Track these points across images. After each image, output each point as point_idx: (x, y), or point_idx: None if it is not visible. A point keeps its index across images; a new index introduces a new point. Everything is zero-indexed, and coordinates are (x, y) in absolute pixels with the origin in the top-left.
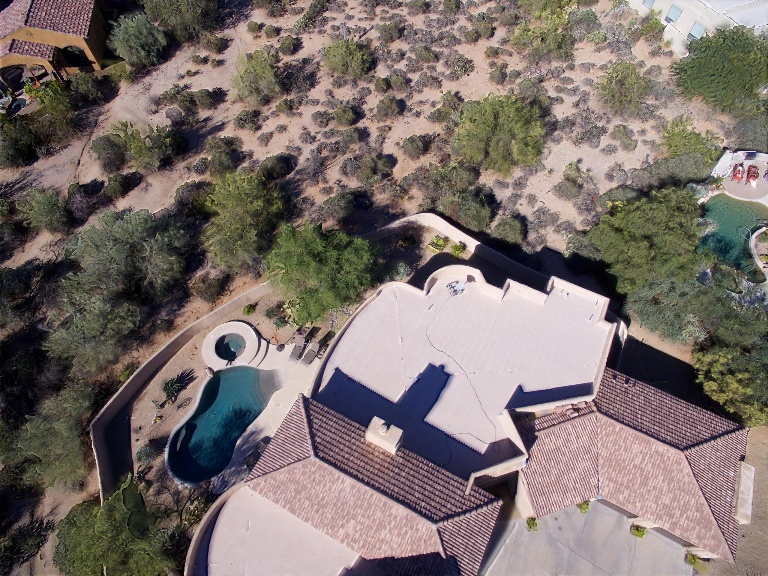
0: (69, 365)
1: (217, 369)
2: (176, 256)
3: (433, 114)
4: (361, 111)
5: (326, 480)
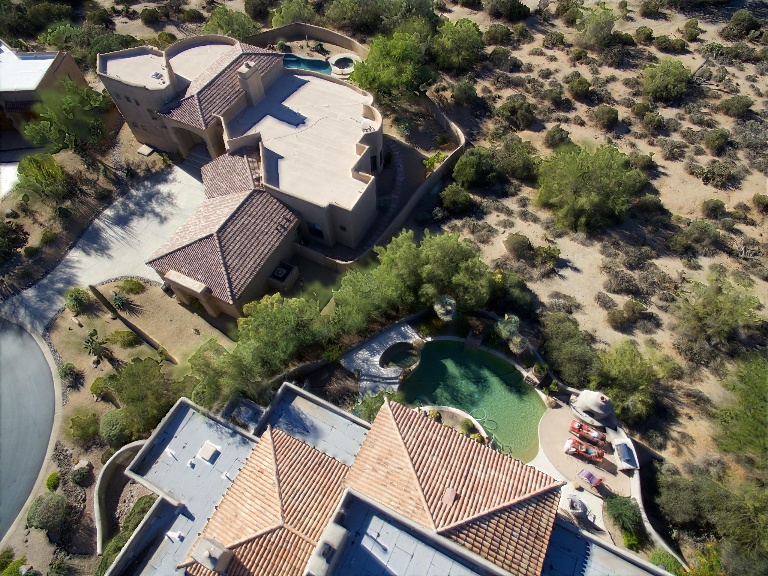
0: None
1: (329, 60)
2: None
3: None
4: (595, 101)
5: None
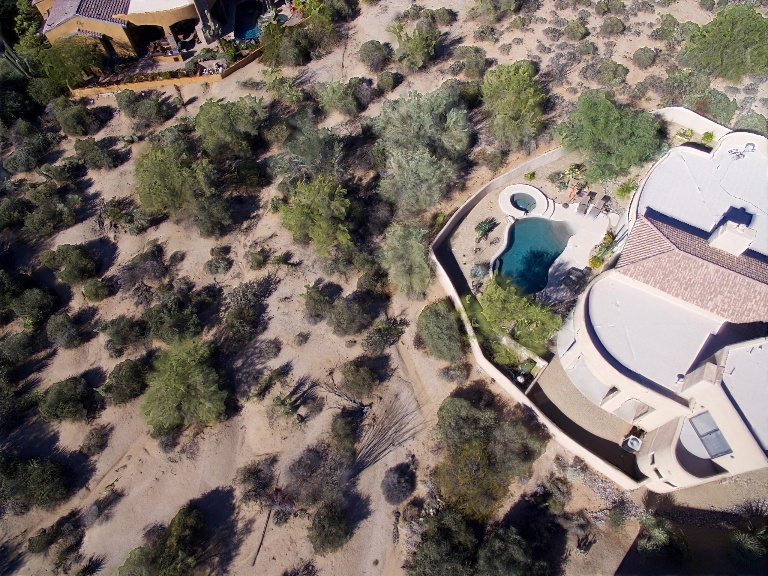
0: (391, 209)
1: (517, 217)
2: (462, 131)
3: (656, 32)
4: (587, 29)
5: (691, 266)
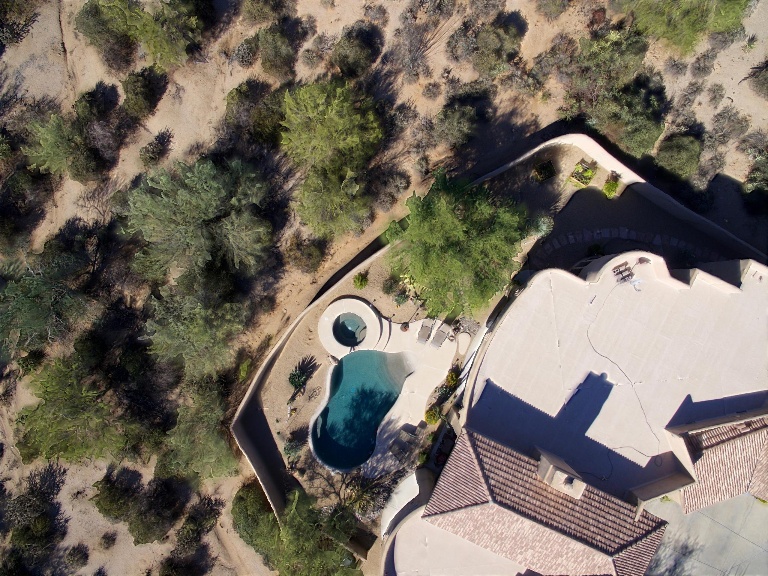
0: (179, 359)
1: (341, 357)
2: (259, 219)
3: None
4: None
5: (505, 521)
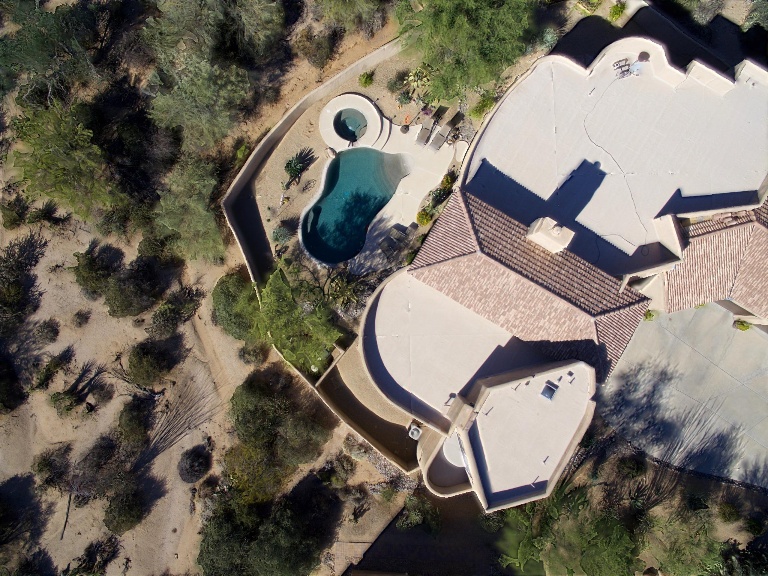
0: (177, 136)
1: (339, 150)
2: (273, 1)
3: None
4: None
5: (491, 274)
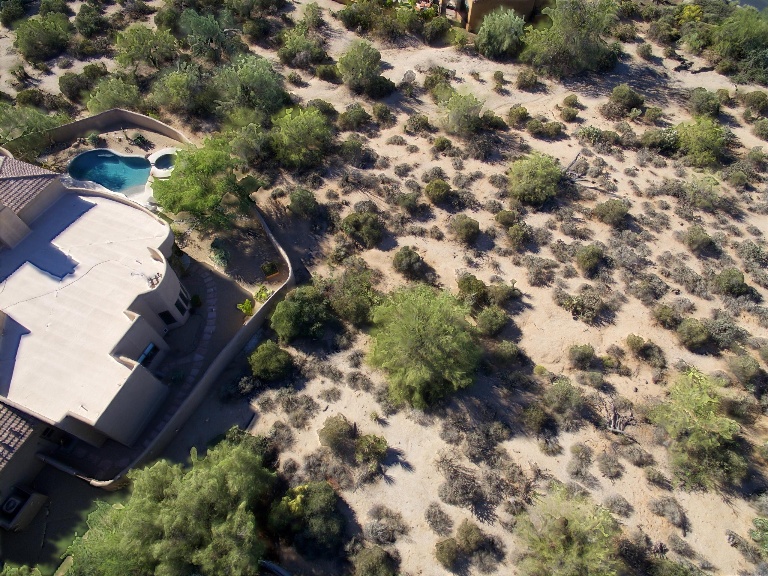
0: None
1: (149, 158)
2: None
3: (465, 274)
4: (456, 206)
5: None
